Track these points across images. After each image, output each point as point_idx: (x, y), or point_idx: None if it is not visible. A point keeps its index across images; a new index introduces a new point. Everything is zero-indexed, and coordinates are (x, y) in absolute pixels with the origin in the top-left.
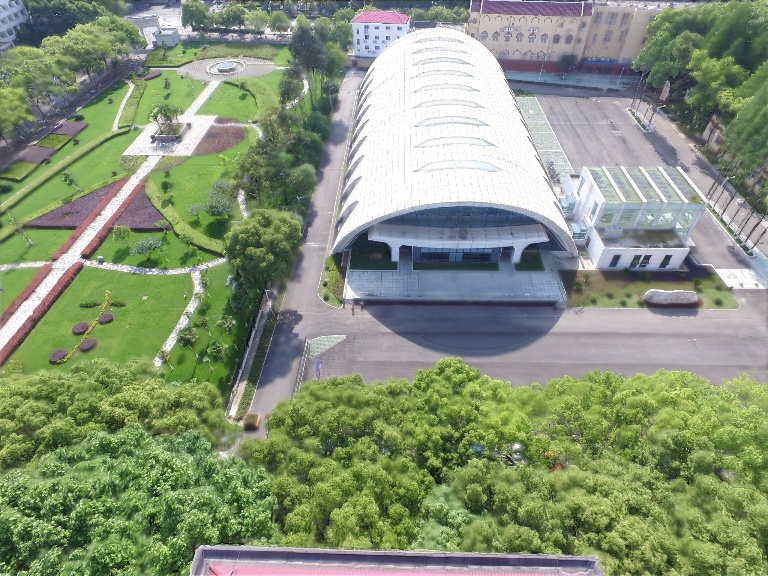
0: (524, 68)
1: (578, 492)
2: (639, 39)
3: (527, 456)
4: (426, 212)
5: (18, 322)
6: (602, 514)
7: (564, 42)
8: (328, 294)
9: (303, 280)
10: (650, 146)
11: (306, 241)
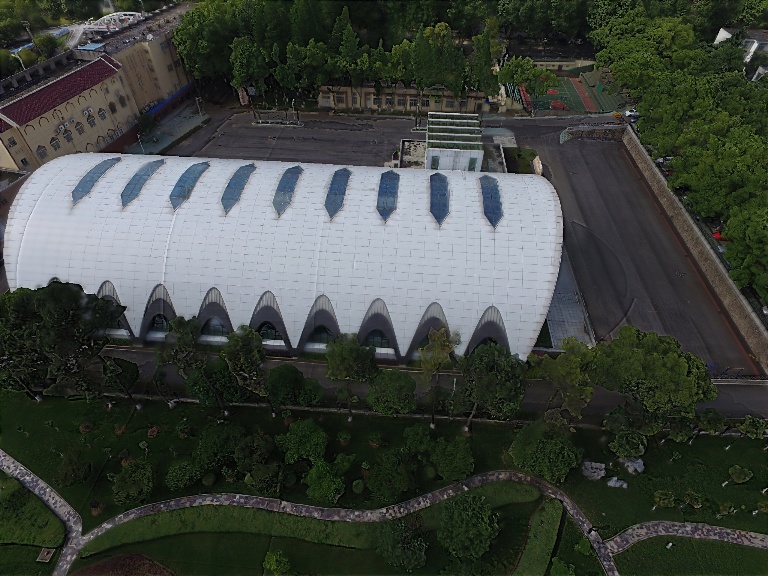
0: None
1: None
2: (166, 69)
3: None
4: None
5: None
6: None
7: (120, 107)
8: None
9: None
10: (327, 130)
11: None
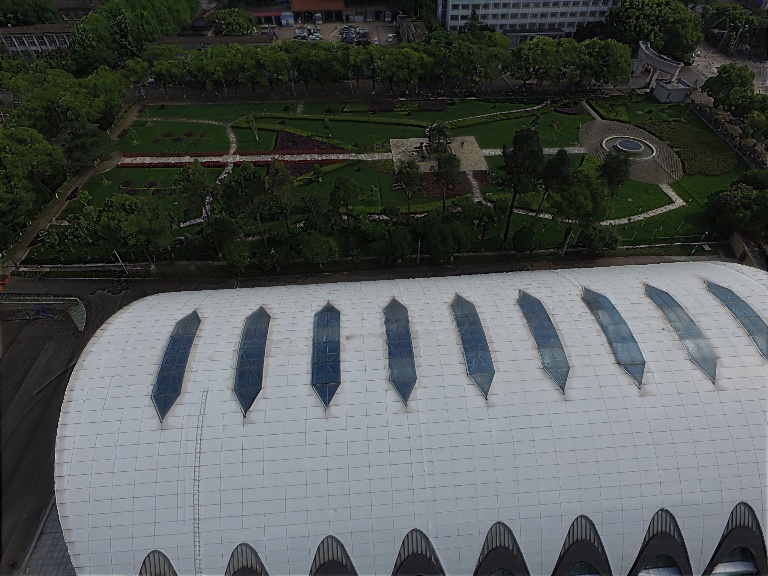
0: None
1: None
2: None
3: None
4: None
5: (169, 161)
6: None
7: None
8: None
9: (175, 288)
10: None
11: (242, 282)
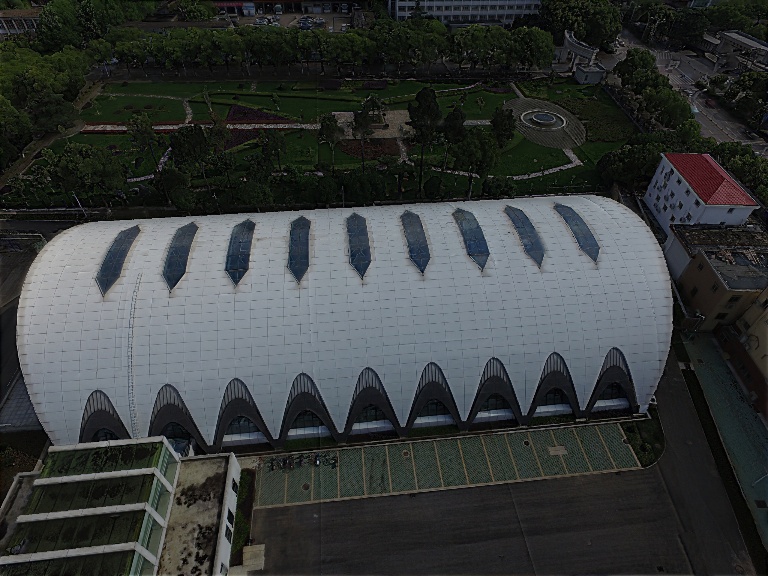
0: None
1: None
2: None
3: None
4: None
5: None
6: None
7: None
8: None
9: None
10: None
11: None
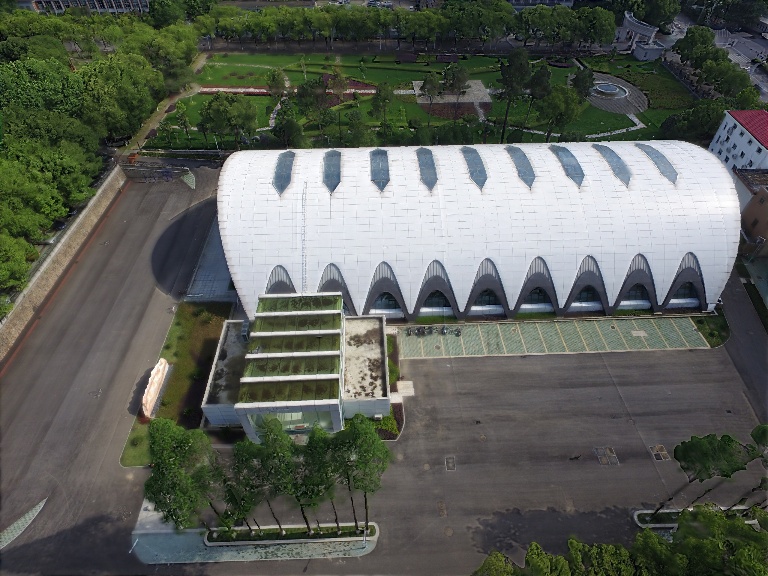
0: None
1: None
2: None
3: None
4: None
5: None
6: None
7: None
8: None
9: None
10: (569, 504)
11: None
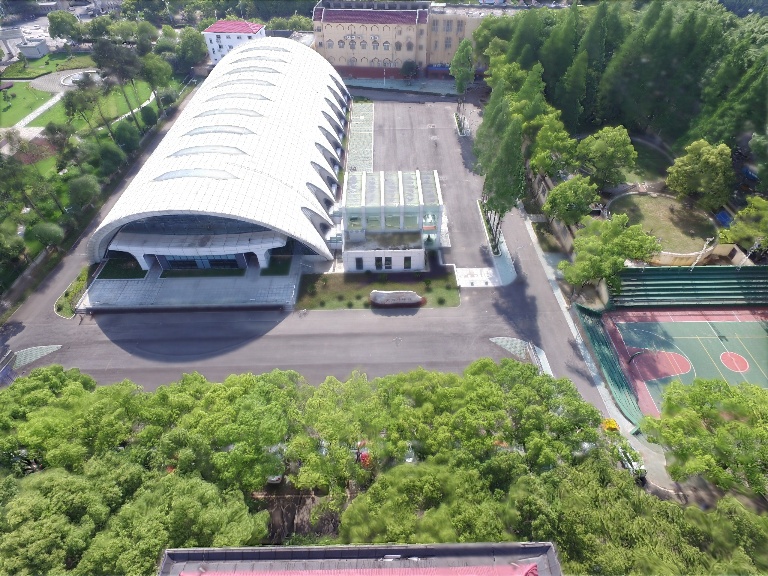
0: (374, 75)
1: (29, 494)
2: None
3: (43, 460)
4: (165, 221)
5: None
6: (19, 514)
7: (406, 49)
8: (64, 304)
9: (48, 291)
10: (458, 150)
11: (74, 252)
